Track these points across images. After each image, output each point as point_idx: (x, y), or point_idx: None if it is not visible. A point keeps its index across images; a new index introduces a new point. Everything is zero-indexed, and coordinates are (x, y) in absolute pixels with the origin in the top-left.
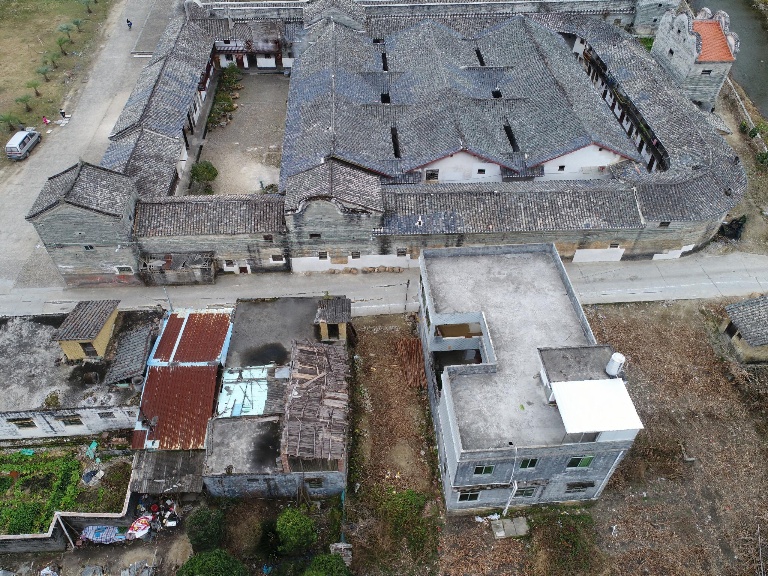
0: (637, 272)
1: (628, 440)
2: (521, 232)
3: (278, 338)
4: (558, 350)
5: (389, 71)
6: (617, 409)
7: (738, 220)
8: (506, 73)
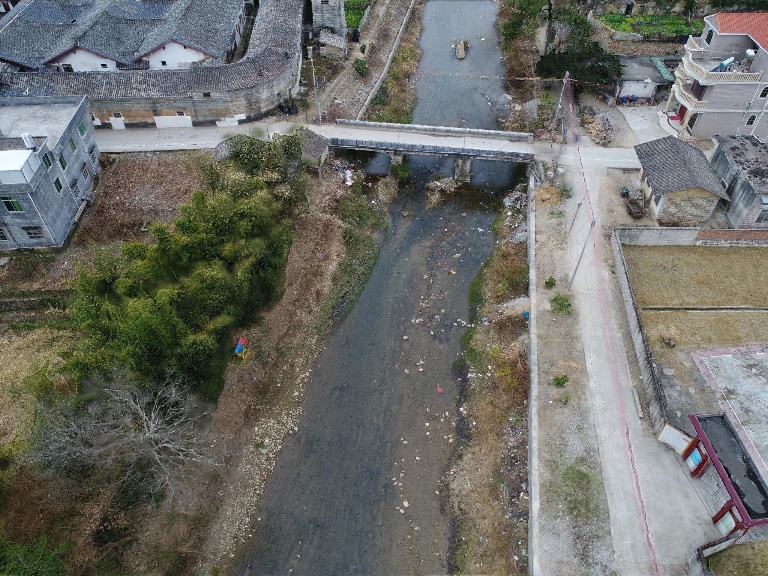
0: (199, 133)
1: (24, 183)
2: (102, 100)
3: None
4: (11, 139)
5: (83, 4)
6: (13, 162)
7: (301, 103)
8: (172, 4)
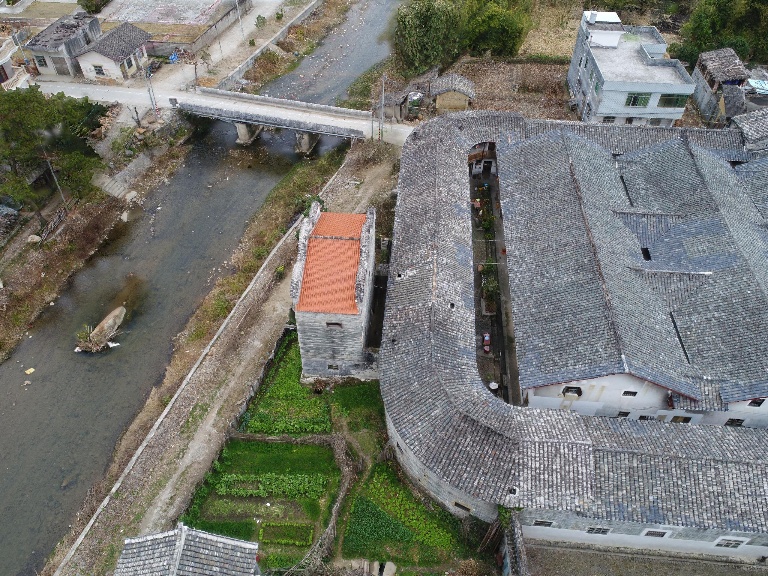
0: None
1: None
2: None
3: (761, 107)
4: None
5: None
6: None
7: None
8: None
